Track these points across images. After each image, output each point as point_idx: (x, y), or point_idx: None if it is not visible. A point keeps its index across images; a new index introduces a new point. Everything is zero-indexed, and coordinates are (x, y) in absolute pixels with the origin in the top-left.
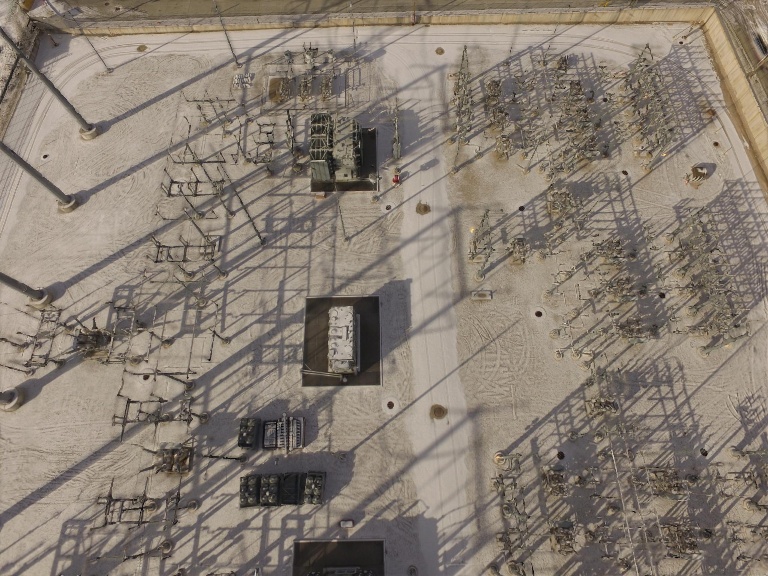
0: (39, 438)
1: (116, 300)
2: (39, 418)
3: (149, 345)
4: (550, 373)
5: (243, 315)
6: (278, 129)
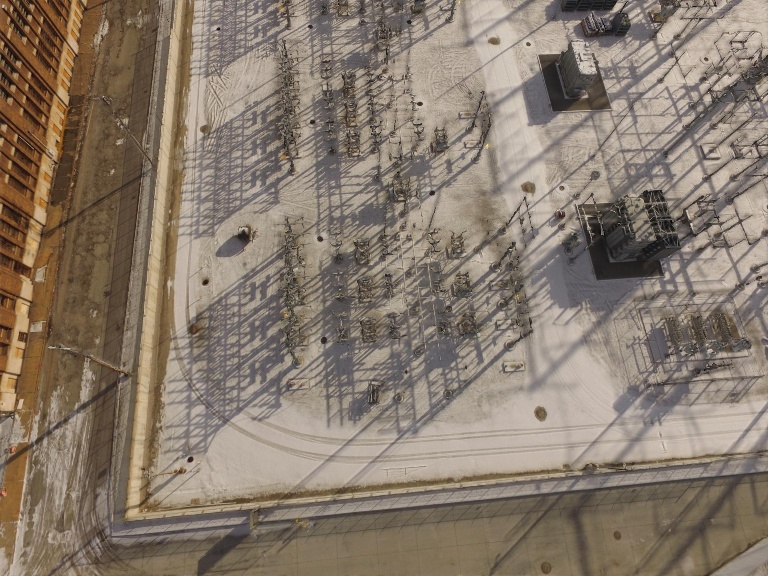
0: (755, 28)
1: (761, 108)
2: (763, 38)
3: (720, 52)
4: (413, 66)
5: (656, 98)
6: (704, 277)
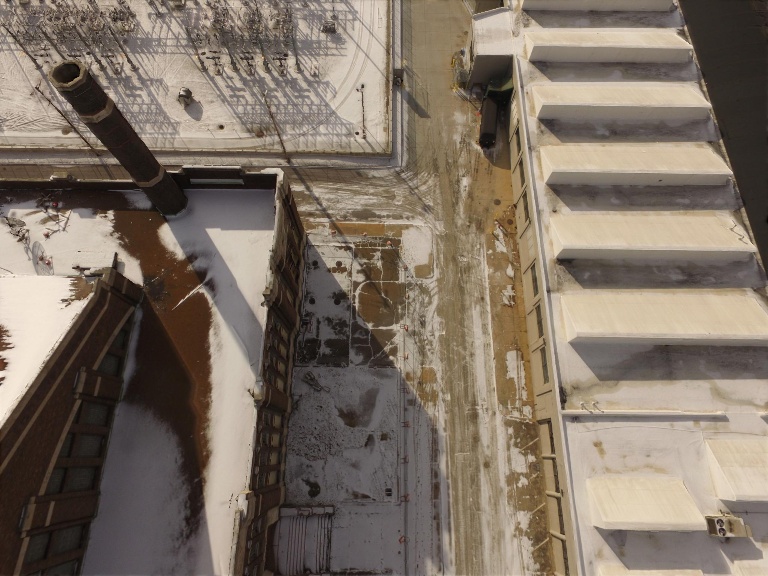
0: None
1: None
2: None
3: None
4: None
5: None
6: None
